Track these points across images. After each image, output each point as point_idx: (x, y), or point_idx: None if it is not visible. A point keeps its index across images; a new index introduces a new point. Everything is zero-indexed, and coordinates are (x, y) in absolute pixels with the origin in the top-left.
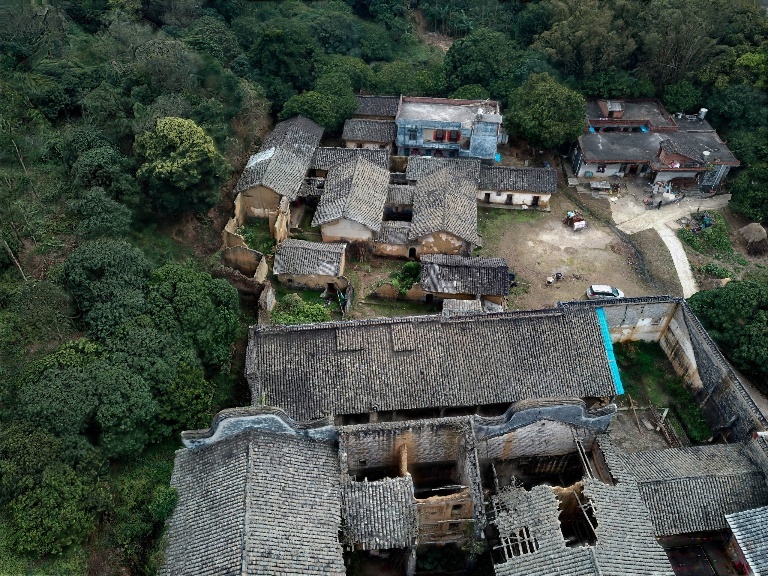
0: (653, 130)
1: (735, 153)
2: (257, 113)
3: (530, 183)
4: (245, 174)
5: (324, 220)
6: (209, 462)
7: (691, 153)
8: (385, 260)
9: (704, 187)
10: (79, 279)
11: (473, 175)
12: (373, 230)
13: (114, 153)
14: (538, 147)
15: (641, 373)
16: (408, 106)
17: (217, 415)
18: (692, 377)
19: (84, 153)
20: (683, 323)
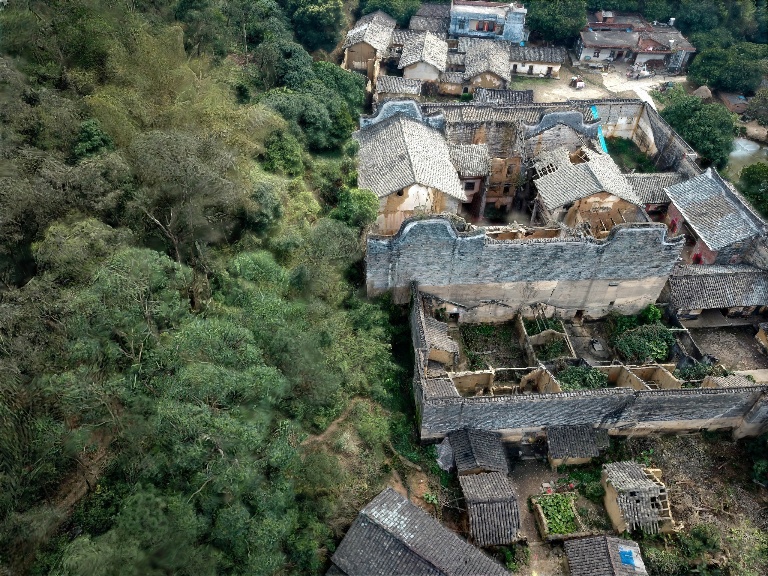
0: (635, 31)
1: (693, 44)
2: (352, 4)
3: (546, 56)
4: (348, 39)
5: (407, 63)
6: (375, 131)
7: (661, 41)
8: (446, 98)
9: (670, 69)
10: (279, 56)
11: (506, 50)
12: (440, 72)
13: (277, 3)
14: (551, 42)
15: (619, 152)
16: (458, 6)
17: (383, 100)
18: (651, 149)
19: (259, 1)
20: (647, 117)
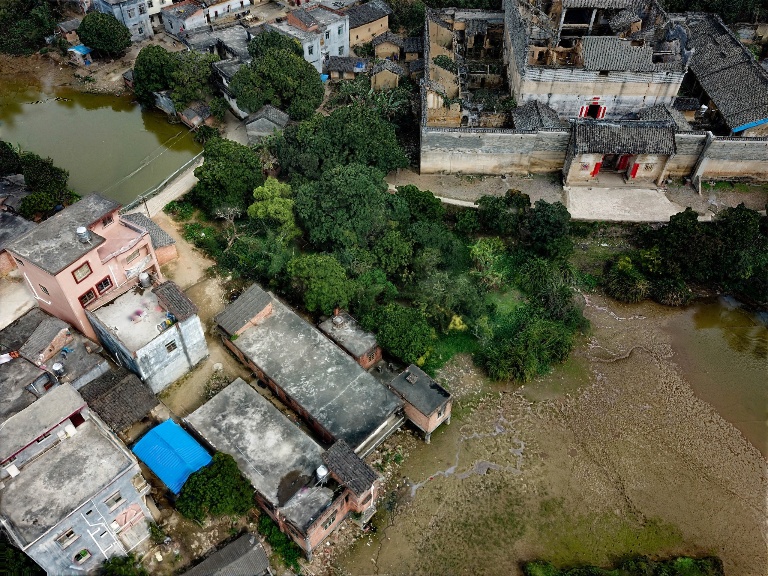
0: None
1: None
2: None
3: None
4: None
5: None
6: None
7: None
8: None
9: None
10: None
11: None
12: None
13: None
14: None
15: None
16: None
17: None
18: None
19: None
20: None
